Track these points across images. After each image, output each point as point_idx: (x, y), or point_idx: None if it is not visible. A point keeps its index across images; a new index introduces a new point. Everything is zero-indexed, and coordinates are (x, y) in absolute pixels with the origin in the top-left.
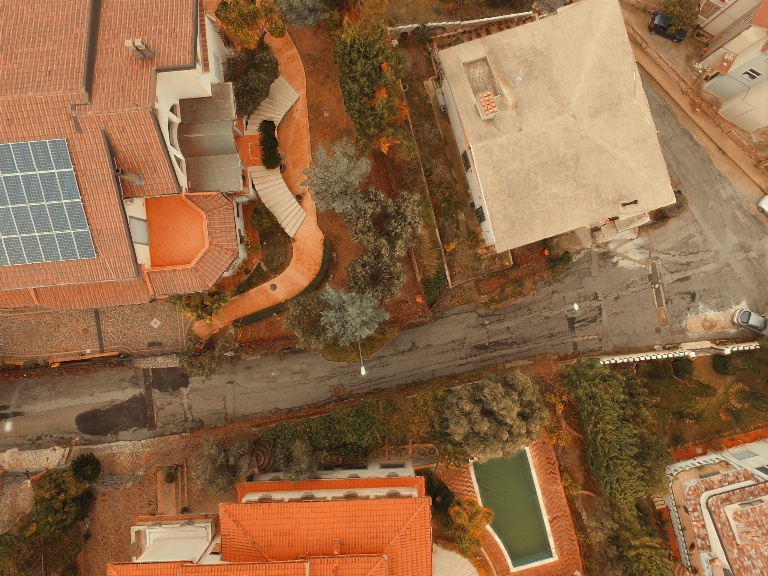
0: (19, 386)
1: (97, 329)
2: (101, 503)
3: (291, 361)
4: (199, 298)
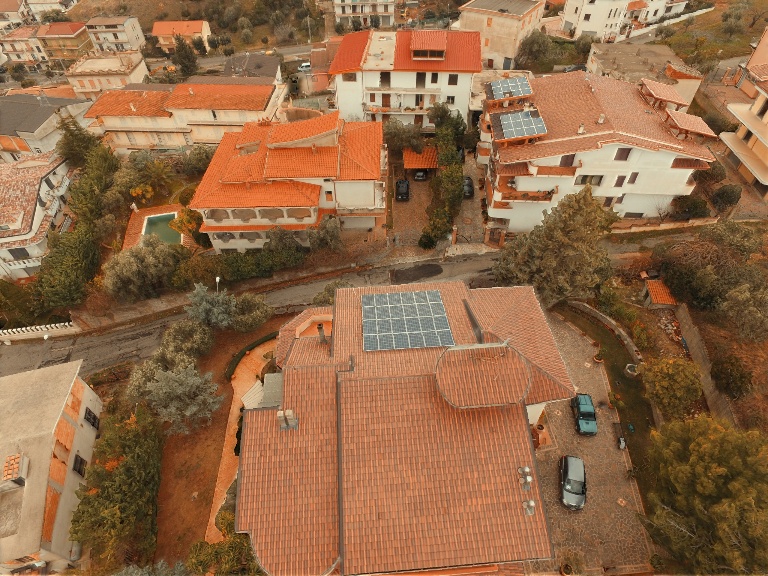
0: (483, 286)
1: None
2: None
3: None
4: None
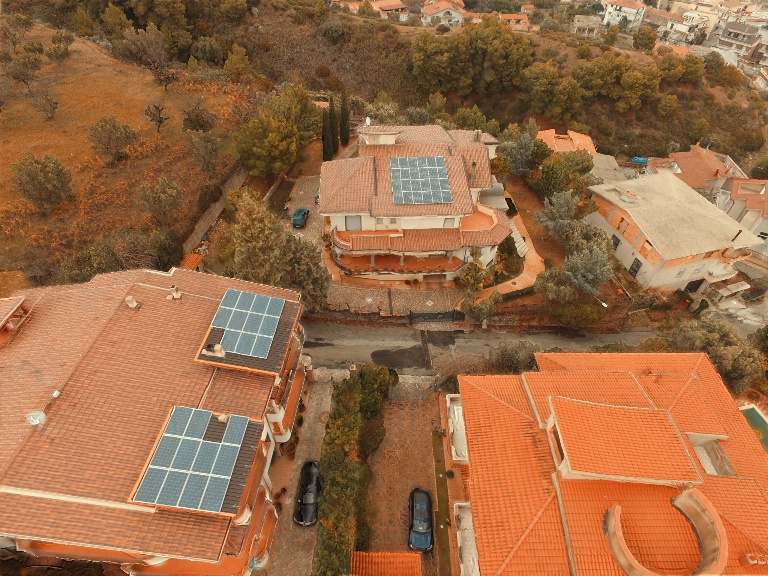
0: (333, 328)
1: (389, 303)
2: (388, 421)
3: (529, 339)
4: (477, 268)
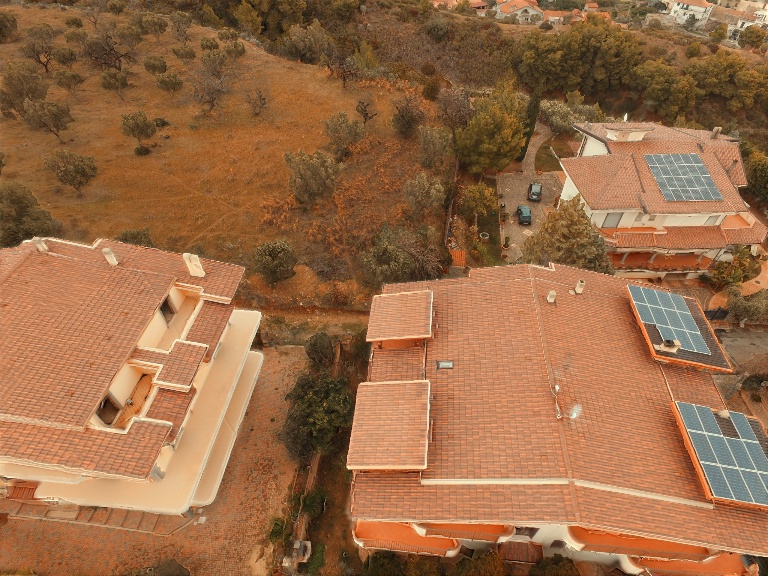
0: None
1: None
2: None
3: None
4: (733, 266)
